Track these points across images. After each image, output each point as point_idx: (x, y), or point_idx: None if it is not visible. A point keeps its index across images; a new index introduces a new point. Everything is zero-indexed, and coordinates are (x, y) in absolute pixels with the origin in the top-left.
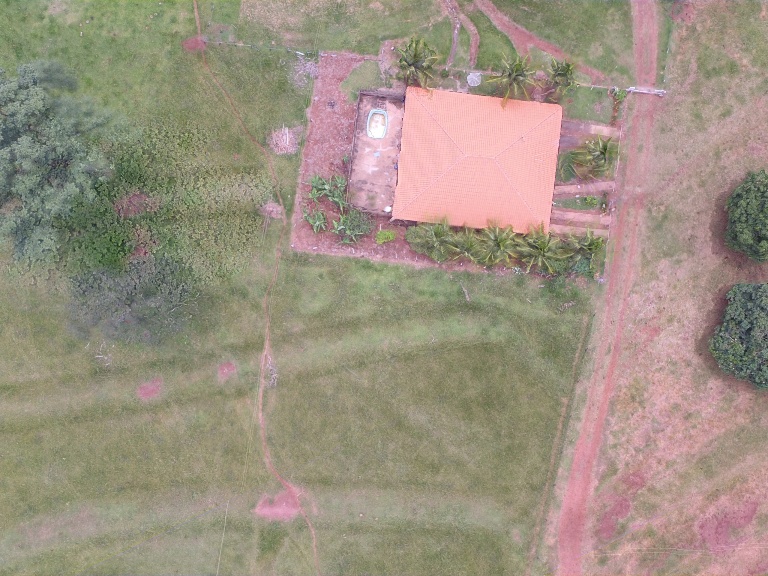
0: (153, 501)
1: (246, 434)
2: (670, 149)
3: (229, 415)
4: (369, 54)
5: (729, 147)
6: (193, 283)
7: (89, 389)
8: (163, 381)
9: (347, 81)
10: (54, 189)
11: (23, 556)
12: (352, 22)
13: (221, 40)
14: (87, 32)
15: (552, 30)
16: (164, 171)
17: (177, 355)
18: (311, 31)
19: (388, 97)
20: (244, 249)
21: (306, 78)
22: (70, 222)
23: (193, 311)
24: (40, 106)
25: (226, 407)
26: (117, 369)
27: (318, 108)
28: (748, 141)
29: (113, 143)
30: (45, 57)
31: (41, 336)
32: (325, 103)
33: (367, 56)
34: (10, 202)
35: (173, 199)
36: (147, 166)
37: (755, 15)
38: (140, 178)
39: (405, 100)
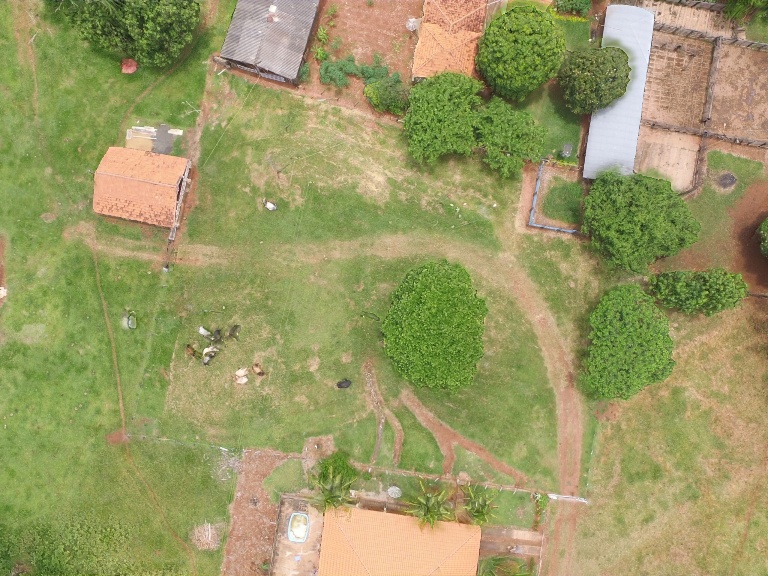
0: None
1: None
2: (592, 555)
3: None
4: (293, 452)
5: (652, 552)
6: None
7: None
8: None
9: (270, 478)
10: None
11: None
12: (277, 416)
13: (145, 434)
14: (11, 425)
15: (477, 428)
16: (85, 568)
17: None
18: (235, 426)
19: (310, 501)
20: None
21: (229, 473)
22: None
23: None
24: None
25: None
26: None
27: (241, 504)
28: (671, 546)
29: (35, 537)
30: None
31: None
32: (248, 500)
33: (291, 454)
34: None
35: None
36: (68, 563)
37: (680, 415)
38: (60, 575)
39: (324, 518)
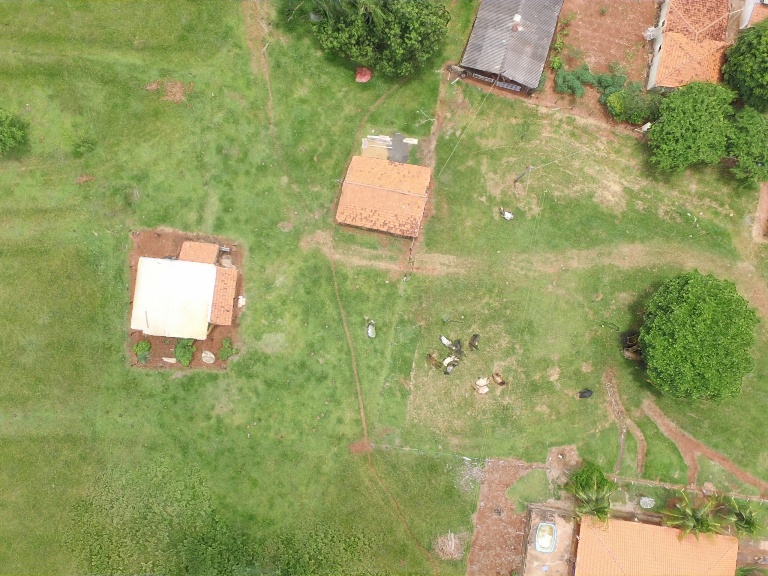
0: None
1: None
2: None
3: None
4: (536, 461)
5: None
6: None
7: None
8: None
9: (514, 488)
10: None
11: None
12: (519, 426)
13: (388, 443)
14: (254, 434)
15: (720, 438)
16: None
17: None
18: (478, 436)
19: (557, 511)
20: None
21: (472, 483)
22: None
23: None
24: (206, 506)
25: None
26: None
27: (484, 514)
28: None
29: (279, 546)
30: (211, 457)
31: None
32: (491, 510)
33: (534, 463)
34: None
35: None
36: (313, 572)
37: None
38: None
39: (580, 529)
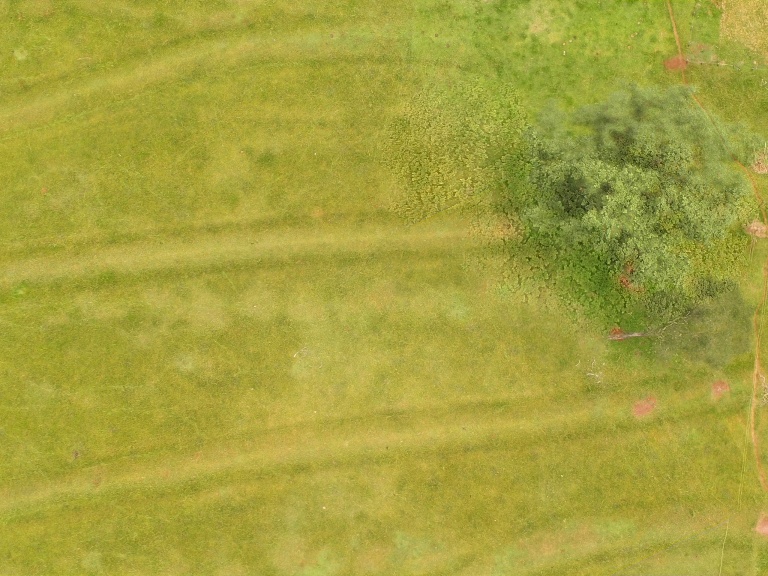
0: (651, 519)
1: (740, 453)
2: None
3: (723, 433)
4: None
5: None
6: (683, 302)
7: (583, 407)
8: (657, 399)
9: None
10: (539, 207)
11: (524, 572)
12: None
13: (703, 60)
14: (570, 51)
15: None
16: (649, 190)
17: (668, 373)
18: None
19: None
20: (732, 268)
21: None
22: (557, 240)
23: (683, 330)
24: (522, 125)
25: (718, 425)
26: (609, 387)
27: None
28: None
29: (596, 162)
30: (526, 76)
31: (532, 353)
32: None
33: None
34: (497, 220)
35: (661, 218)
36: (632, 185)
37: None
38: (626, 197)
39: None
